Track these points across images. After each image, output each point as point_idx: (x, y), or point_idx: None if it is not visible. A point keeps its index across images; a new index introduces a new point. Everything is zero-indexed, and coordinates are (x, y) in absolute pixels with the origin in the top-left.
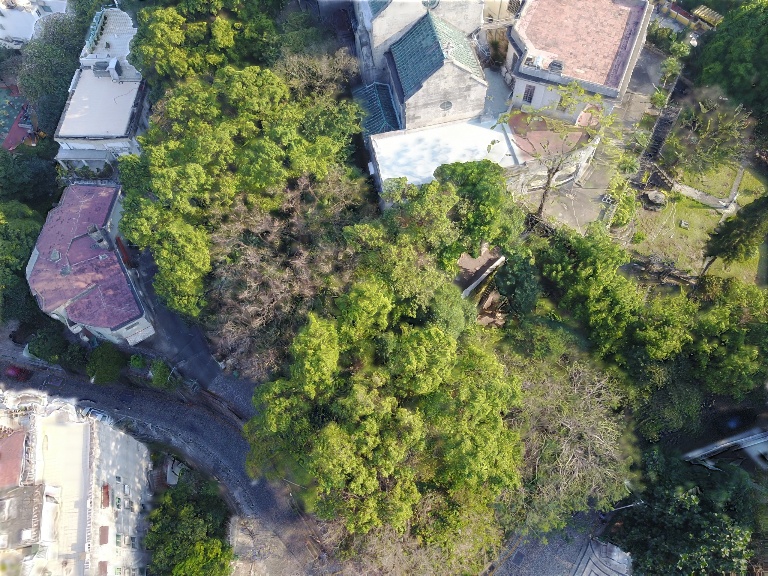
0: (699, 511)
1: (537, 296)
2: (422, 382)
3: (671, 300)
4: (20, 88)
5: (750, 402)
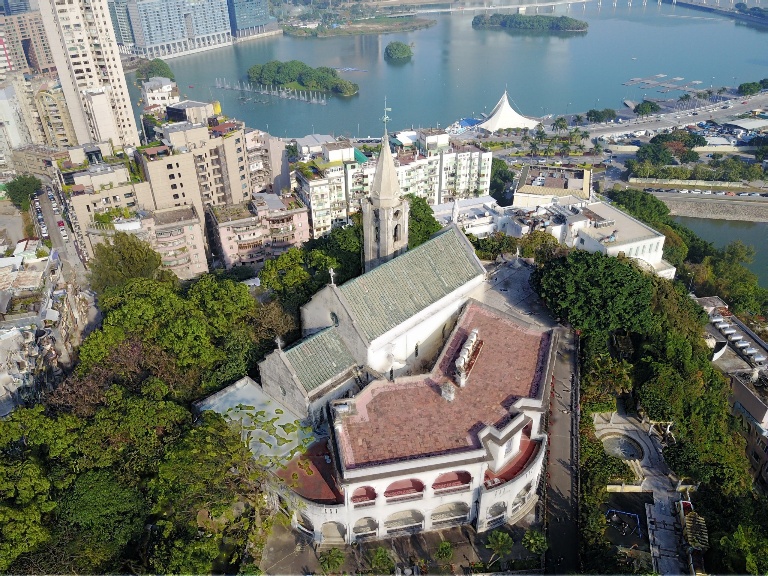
0: None
1: None
2: None
3: None
4: None
5: None
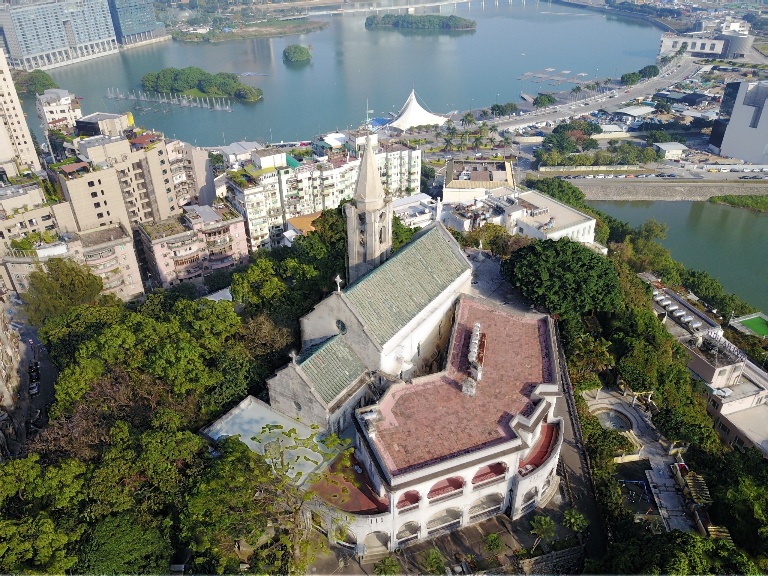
0: None
1: None
2: None
3: None
4: None
5: None
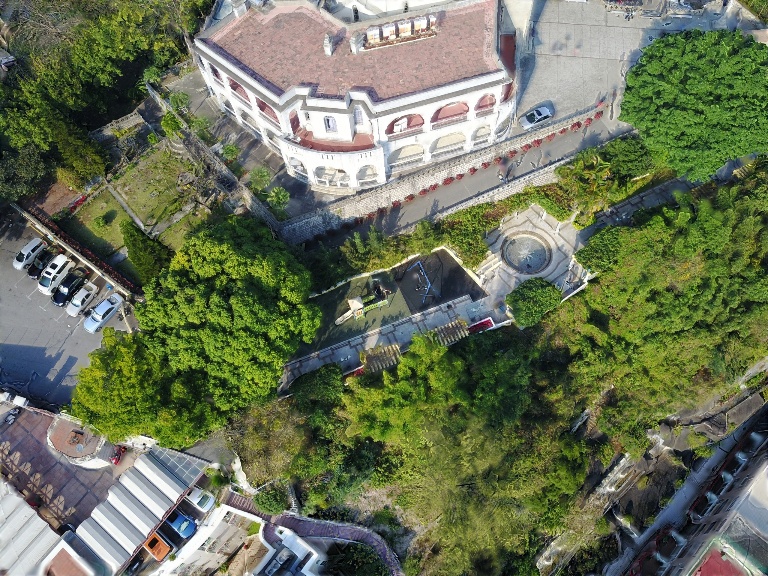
0: None
1: None
2: None
3: None
4: None
5: None
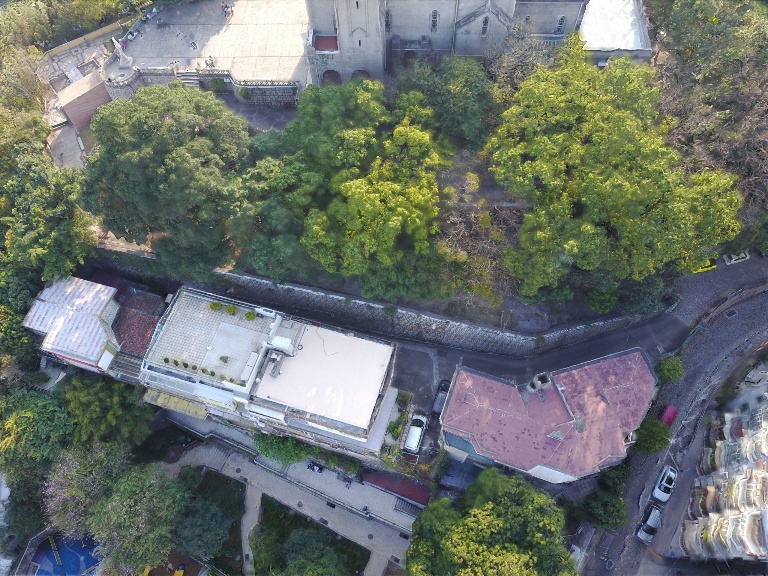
0: None
1: None
2: None
3: None
4: (136, 569)
5: None
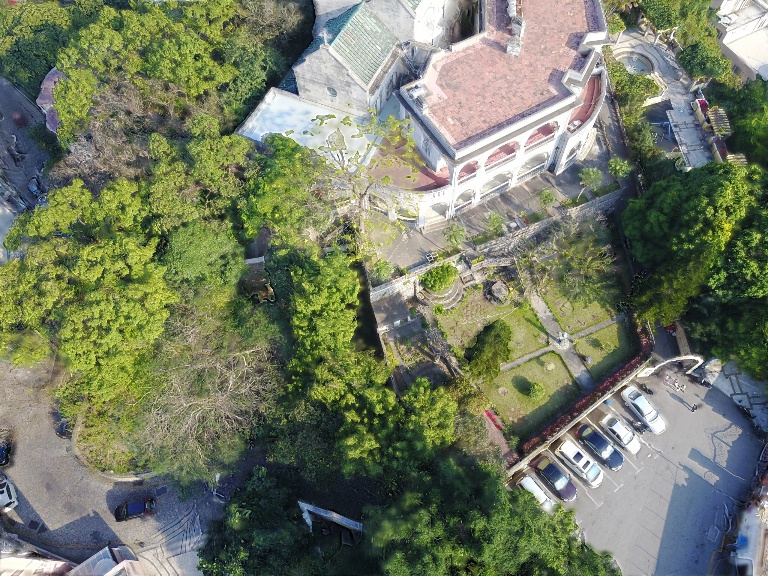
0: (235, 529)
1: (288, 289)
2: (78, 265)
3: (372, 361)
4: None
5: (357, 486)
